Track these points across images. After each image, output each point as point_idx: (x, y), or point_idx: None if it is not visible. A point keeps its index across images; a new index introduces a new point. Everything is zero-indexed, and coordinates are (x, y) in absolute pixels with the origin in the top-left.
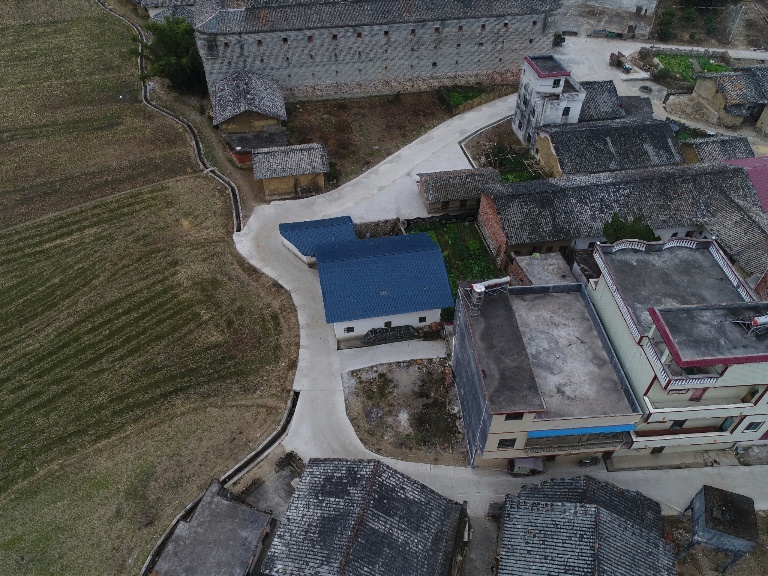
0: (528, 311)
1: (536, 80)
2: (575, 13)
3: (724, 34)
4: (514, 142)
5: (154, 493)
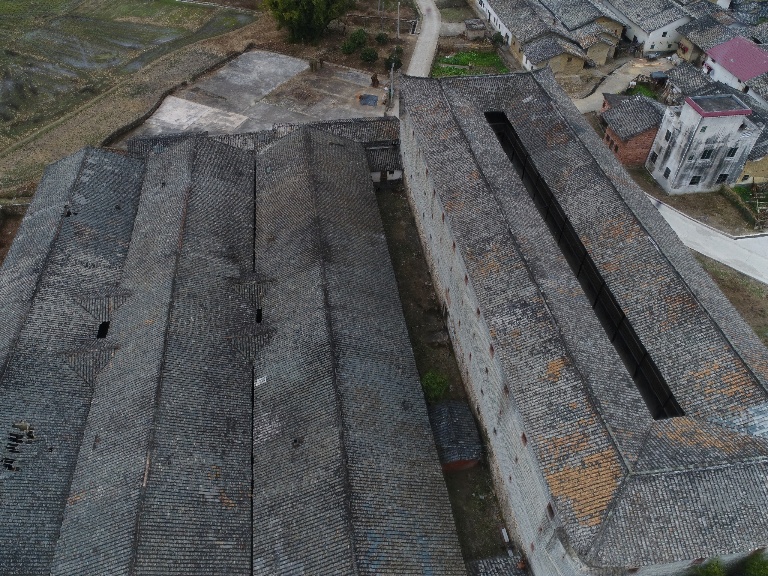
0: None
1: (741, 121)
2: (300, 107)
3: None
4: (702, 198)
5: None
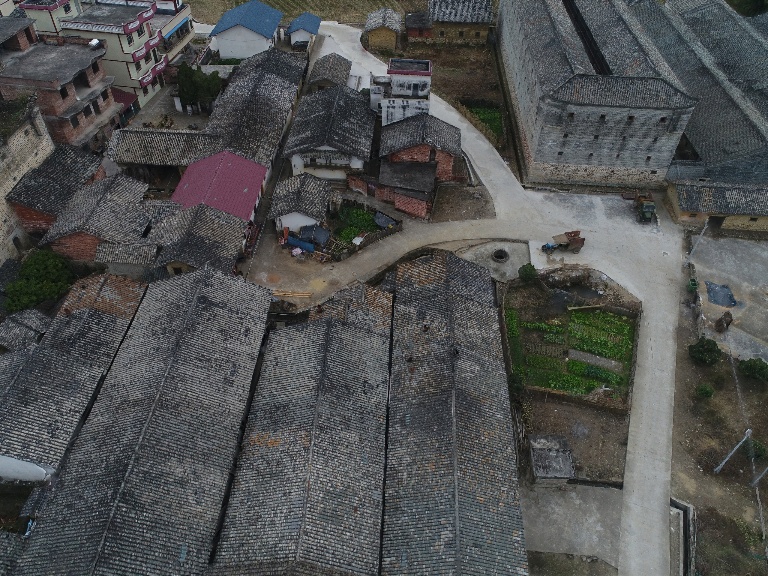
0: (164, 21)
1: None
2: None
3: (763, 489)
4: None
5: (194, 4)
